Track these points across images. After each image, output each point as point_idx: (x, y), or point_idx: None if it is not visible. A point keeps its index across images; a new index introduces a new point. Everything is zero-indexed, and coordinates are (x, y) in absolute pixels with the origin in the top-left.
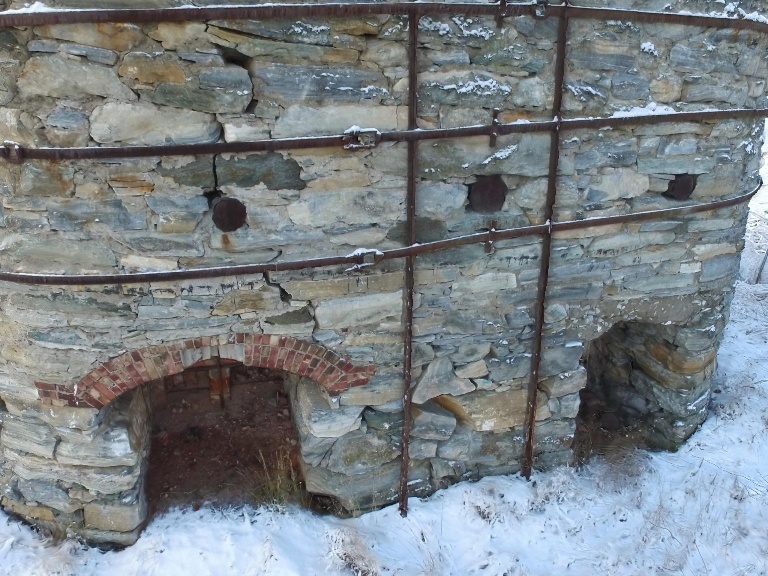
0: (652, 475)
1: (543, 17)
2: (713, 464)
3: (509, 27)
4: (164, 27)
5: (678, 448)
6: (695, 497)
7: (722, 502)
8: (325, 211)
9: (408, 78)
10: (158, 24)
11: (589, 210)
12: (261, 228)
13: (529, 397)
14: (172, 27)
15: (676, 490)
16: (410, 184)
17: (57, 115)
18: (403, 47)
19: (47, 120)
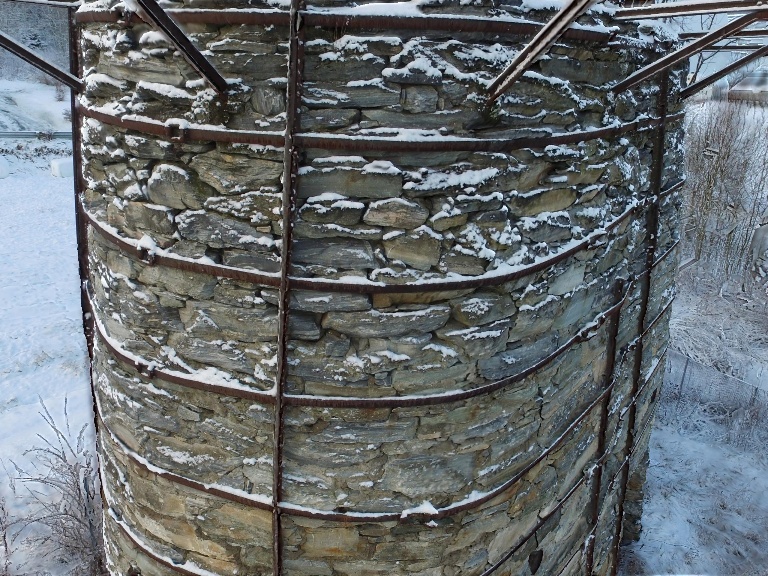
0: (646, 567)
1: (635, 348)
2: (663, 542)
3: (624, 361)
4: (532, 470)
5: (639, 537)
6: (675, 574)
7: (686, 571)
8: (566, 524)
9: (600, 421)
10: (529, 470)
11: None
12: (546, 559)
13: (608, 561)
14: (535, 467)
15: (663, 573)
16: (596, 482)
17: (472, 559)
18: (600, 405)
19: (465, 566)
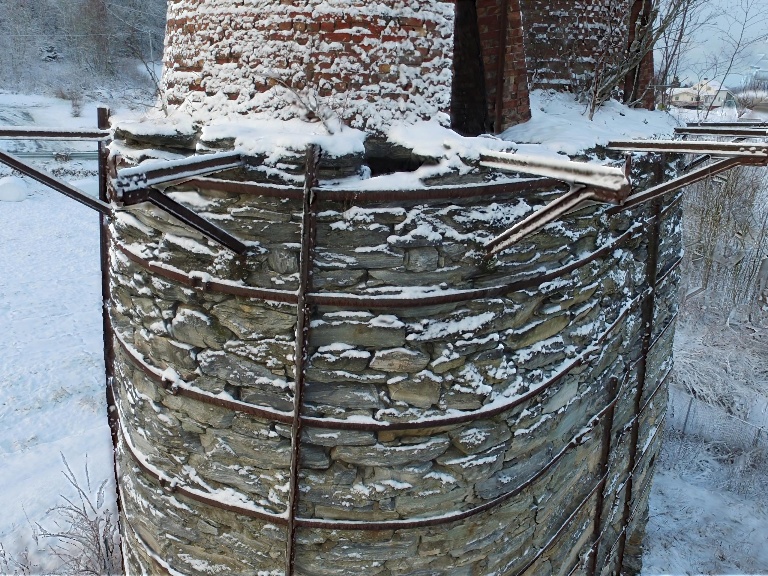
0: None
1: None
2: None
3: None
4: (527, 570)
5: None
6: None
7: None
8: None
9: (596, 506)
10: None
11: (632, 505)
12: None
13: None
14: (530, 567)
15: None
16: (592, 561)
17: None
18: (596, 492)
19: None
